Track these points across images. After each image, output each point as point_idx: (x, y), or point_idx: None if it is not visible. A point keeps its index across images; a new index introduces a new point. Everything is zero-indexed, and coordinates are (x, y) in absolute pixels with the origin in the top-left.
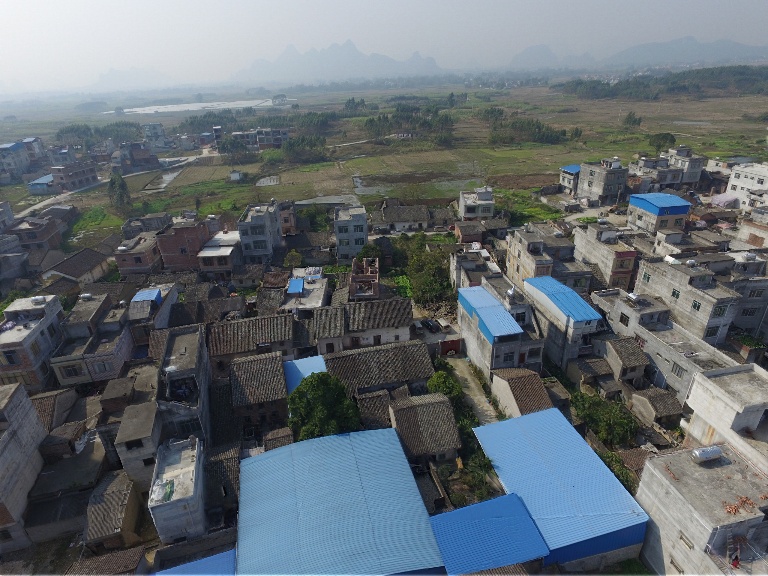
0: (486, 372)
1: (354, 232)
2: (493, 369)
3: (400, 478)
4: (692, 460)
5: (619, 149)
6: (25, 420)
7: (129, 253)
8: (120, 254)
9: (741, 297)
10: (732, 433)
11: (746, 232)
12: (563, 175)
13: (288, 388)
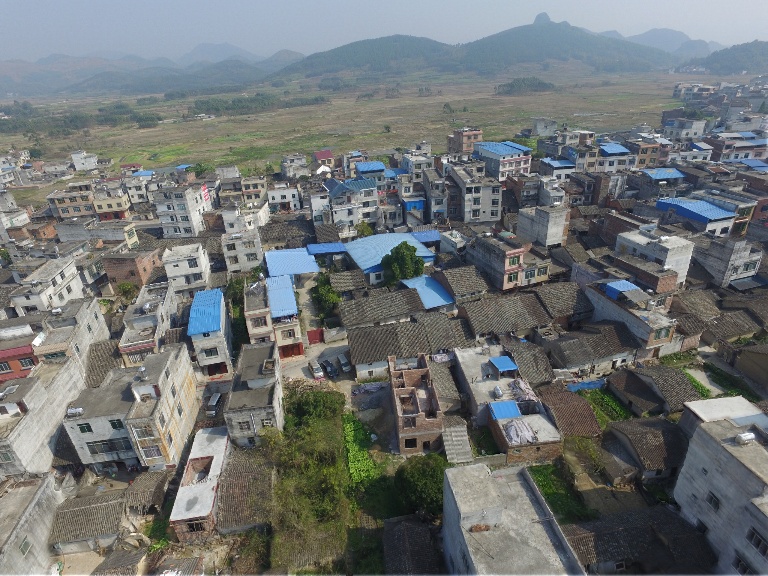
0: None
1: None
2: None
3: None
4: (243, 238)
5: None
6: (541, 226)
7: None
8: None
9: (71, 301)
10: None
11: None
12: None
13: (434, 280)
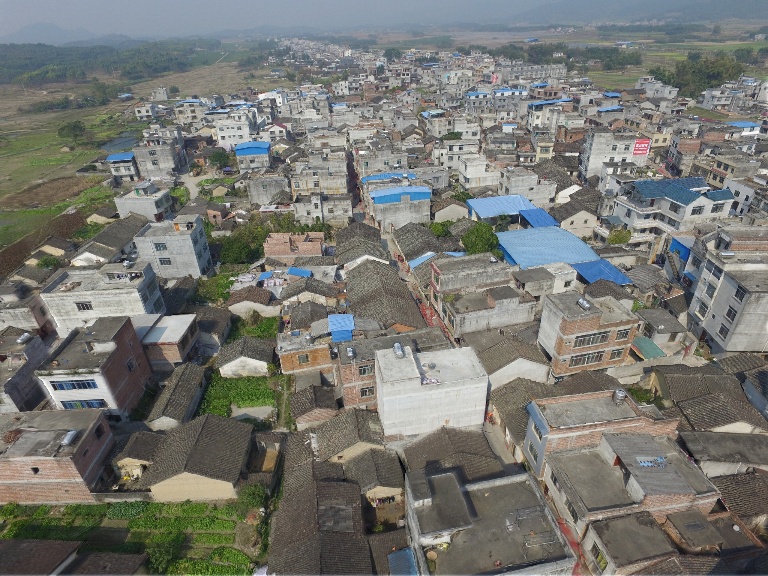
0: (425, 219)
1: (200, 240)
2: (432, 212)
3: (518, 231)
4: None
5: (19, 151)
6: None
7: (89, 430)
8: (80, 445)
9: None
10: (486, 173)
11: (318, 143)
12: (115, 166)
13: None
